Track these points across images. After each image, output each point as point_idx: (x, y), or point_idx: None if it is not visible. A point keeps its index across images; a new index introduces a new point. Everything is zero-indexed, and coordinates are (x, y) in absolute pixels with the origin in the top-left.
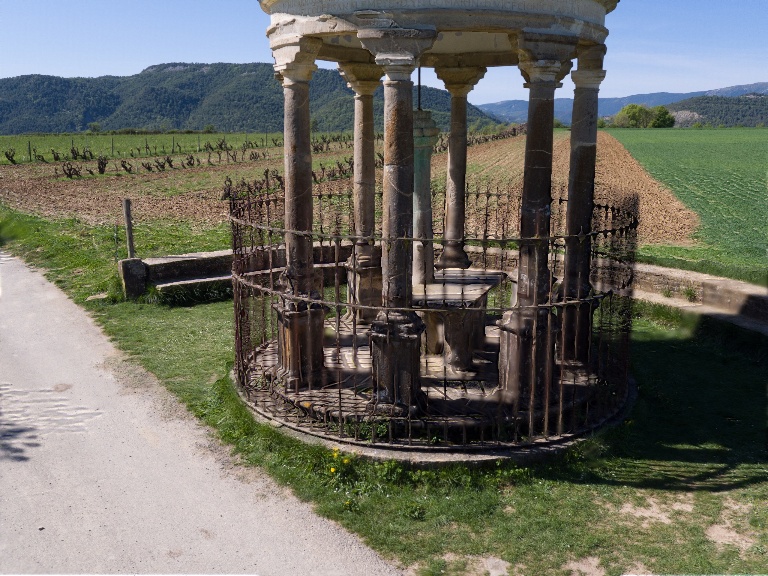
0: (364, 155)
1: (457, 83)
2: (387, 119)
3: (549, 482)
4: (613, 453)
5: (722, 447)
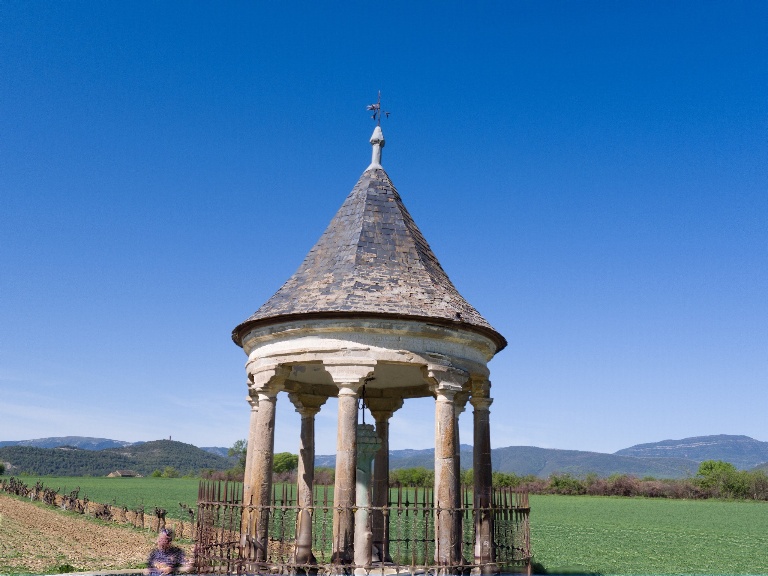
0: None
1: (313, 406)
2: (446, 425)
3: None
4: None
5: None
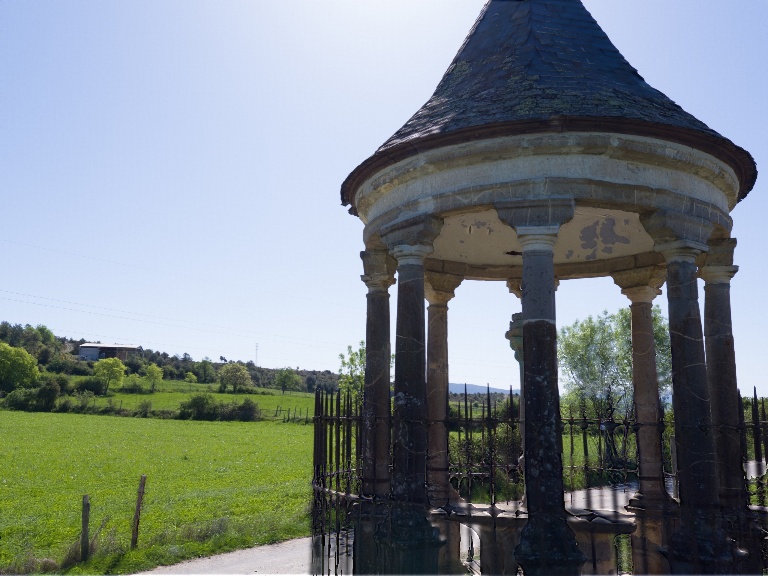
0: (634, 370)
1: None
2: None
3: None
4: None
5: None
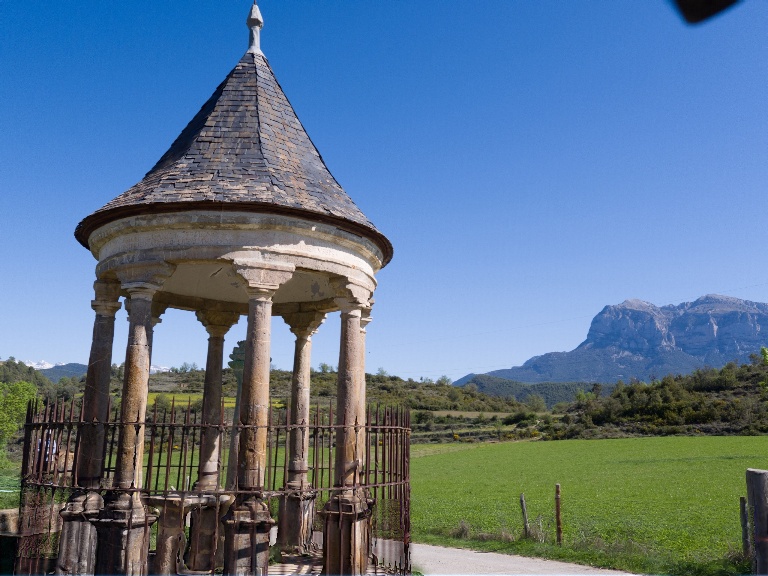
0: None
1: None
2: None
3: None
4: None
5: None
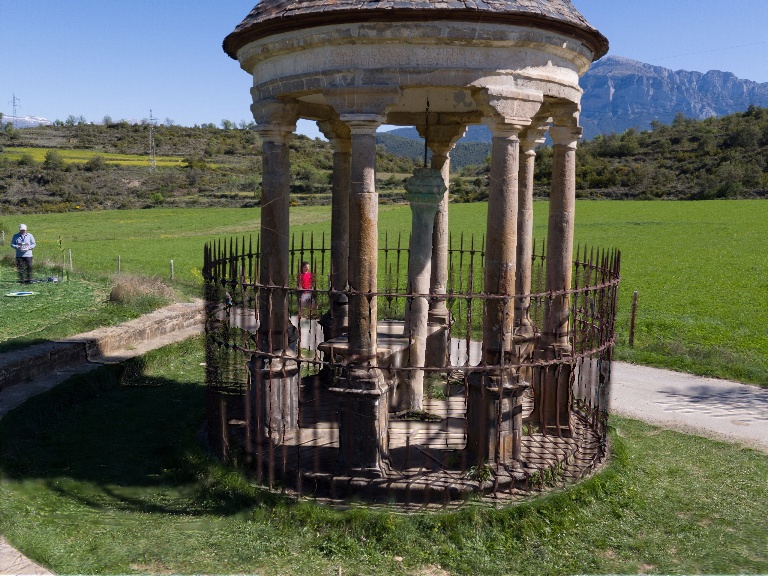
0: None
1: None
2: (447, 181)
3: None
4: None
5: None
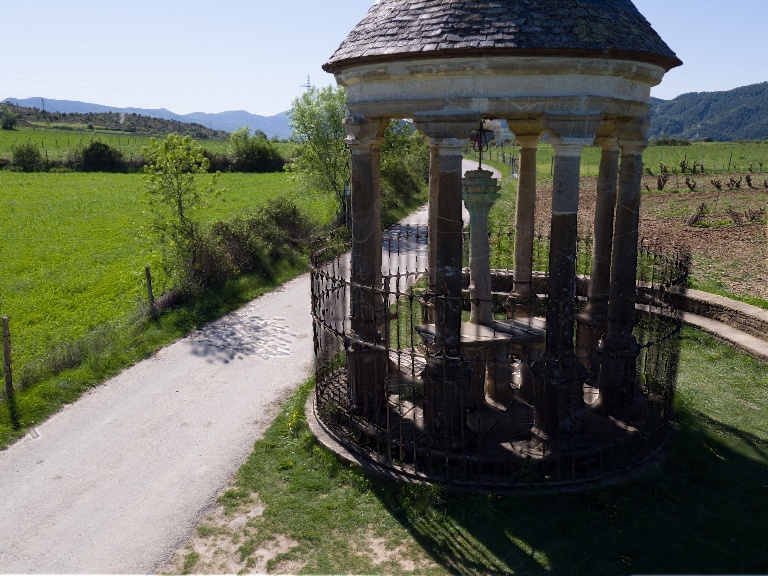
0: (519, 202)
1: (603, 136)
2: None
3: (375, 499)
4: (449, 510)
5: (546, 563)
